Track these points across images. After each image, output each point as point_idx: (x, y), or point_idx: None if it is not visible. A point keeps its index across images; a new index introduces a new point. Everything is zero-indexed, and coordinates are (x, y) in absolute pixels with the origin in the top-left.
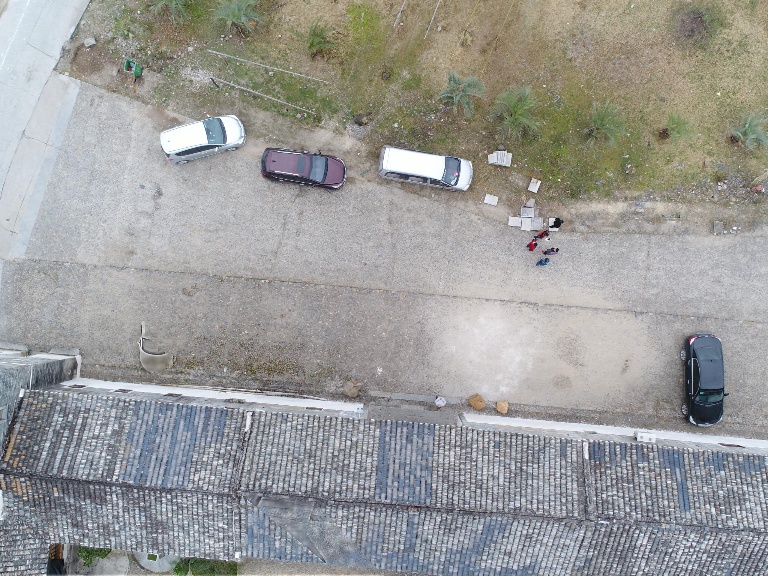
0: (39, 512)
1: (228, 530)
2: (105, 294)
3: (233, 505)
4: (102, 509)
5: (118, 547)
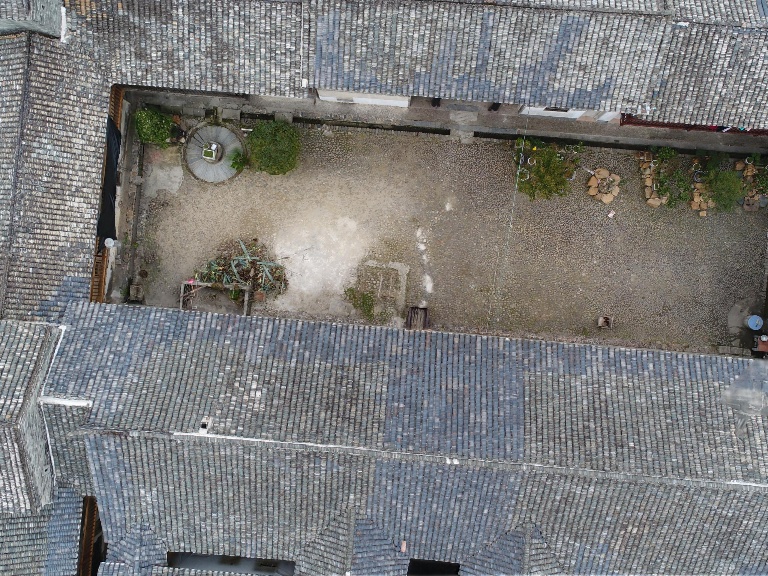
0: (102, 39)
1: (295, 54)
2: None
3: (303, 7)
4: (167, 30)
5: (181, 84)
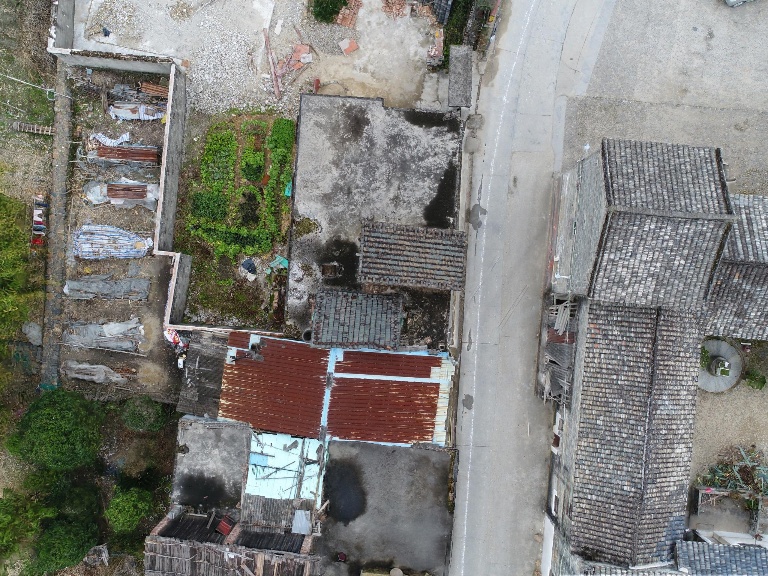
0: (709, 301)
1: None
2: (661, 130)
3: None
4: None
5: None
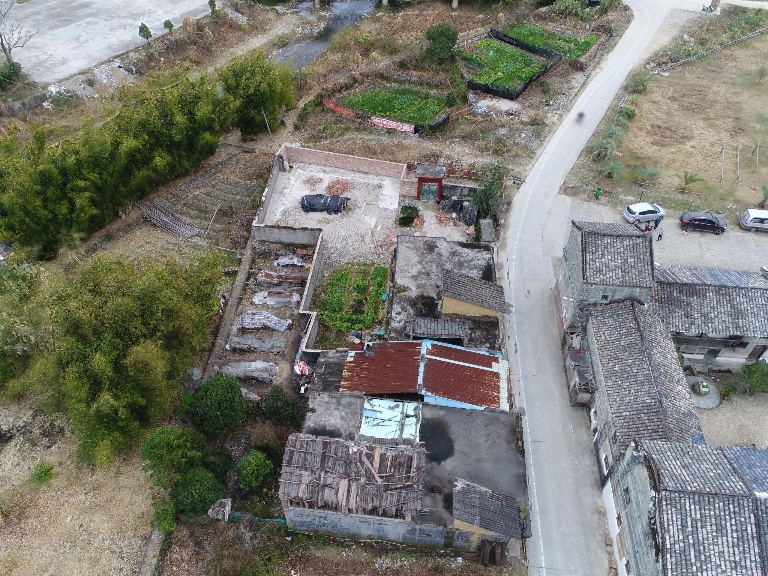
0: (664, 307)
1: None
2: None
3: None
4: (704, 303)
5: (714, 331)
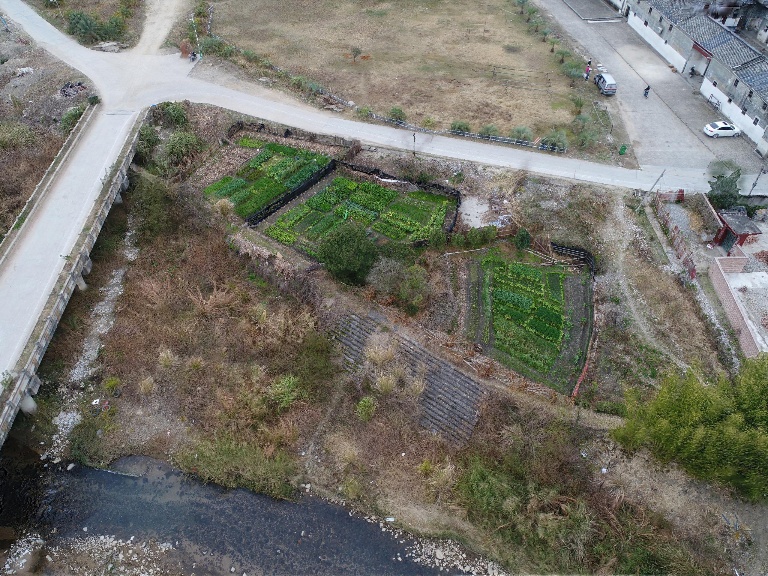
0: None
1: None
2: None
3: None
4: None
5: None
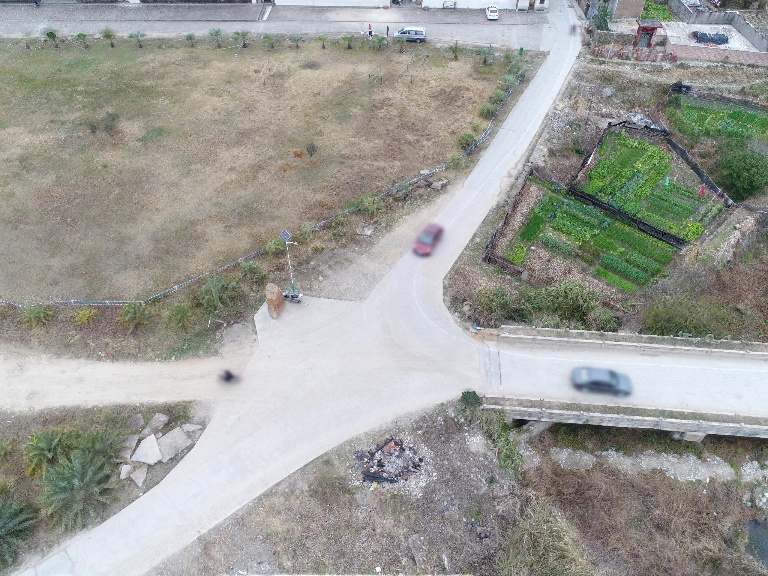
0: None
1: None
2: None
3: None
4: None
5: None
